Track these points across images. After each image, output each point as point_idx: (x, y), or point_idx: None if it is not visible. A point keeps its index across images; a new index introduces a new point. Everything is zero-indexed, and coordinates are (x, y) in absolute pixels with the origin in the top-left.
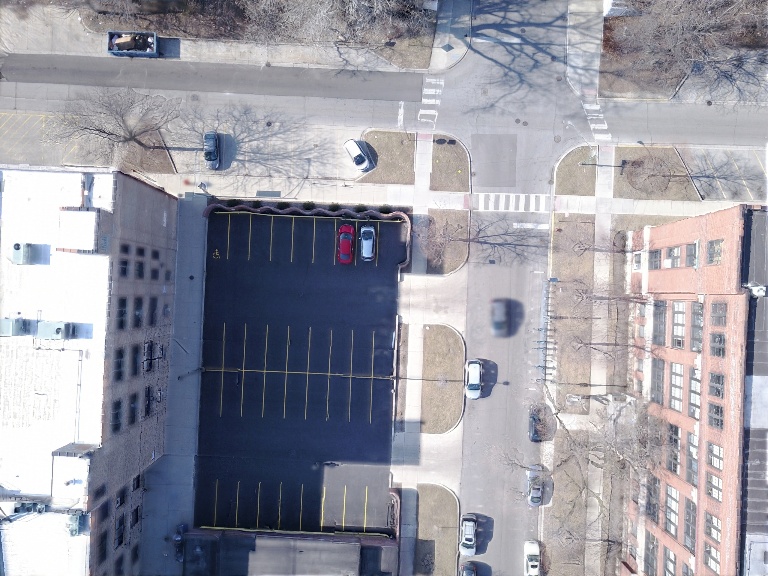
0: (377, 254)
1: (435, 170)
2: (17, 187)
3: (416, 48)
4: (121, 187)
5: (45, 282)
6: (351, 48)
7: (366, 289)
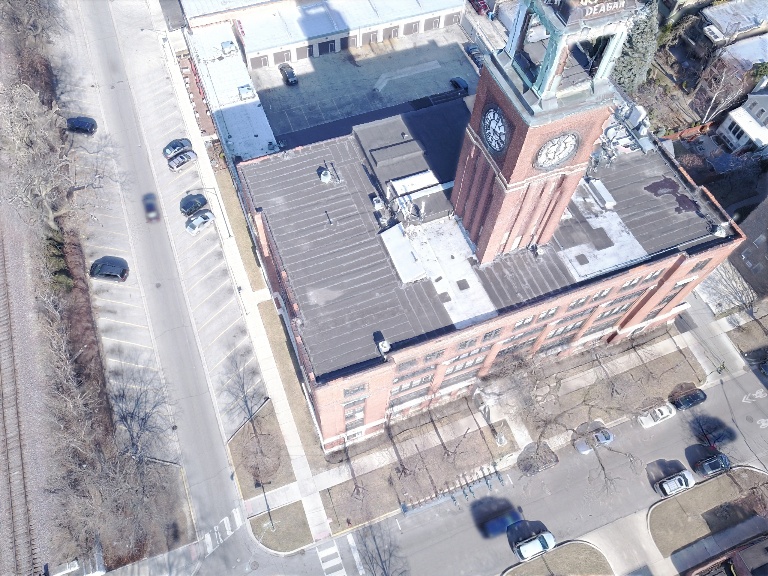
0: None
1: None
2: None
3: None
4: None
5: None
6: None
7: None
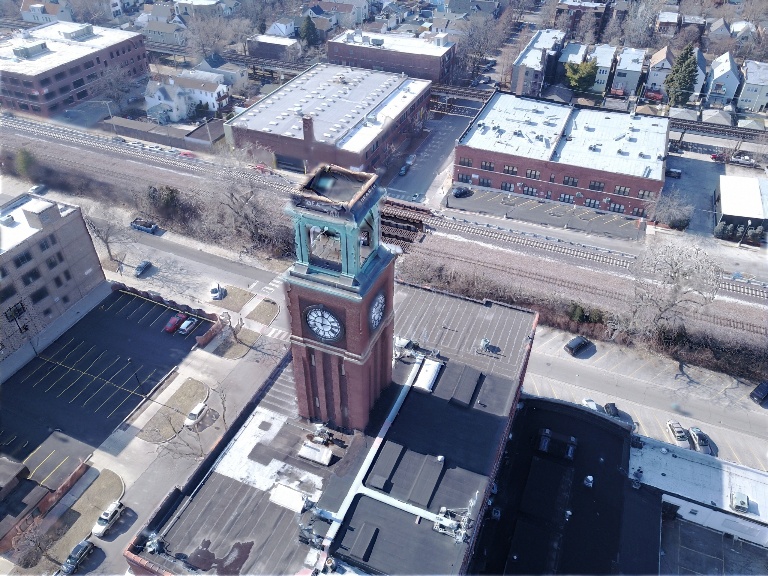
0: (190, 334)
1: (255, 311)
2: (33, 203)
3: (281, 264)
4: (76, 216)
5: (5, 233)
6: (248, 256)
7: (169, 348)
